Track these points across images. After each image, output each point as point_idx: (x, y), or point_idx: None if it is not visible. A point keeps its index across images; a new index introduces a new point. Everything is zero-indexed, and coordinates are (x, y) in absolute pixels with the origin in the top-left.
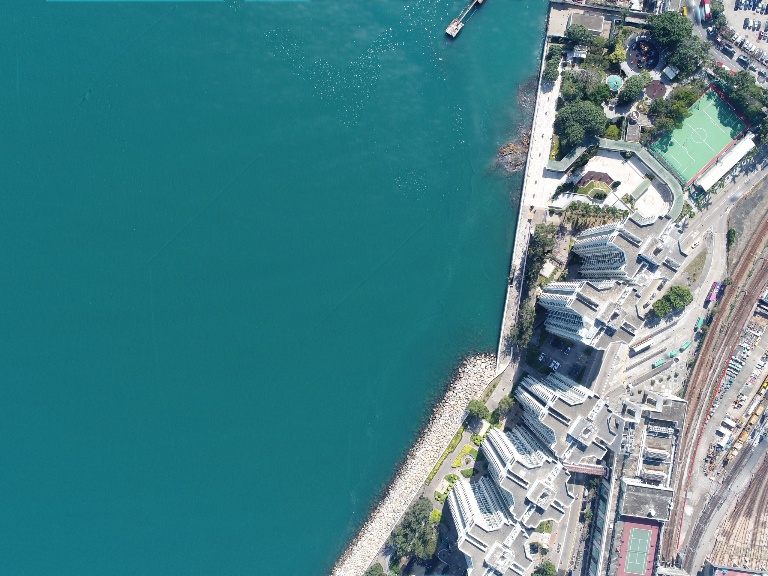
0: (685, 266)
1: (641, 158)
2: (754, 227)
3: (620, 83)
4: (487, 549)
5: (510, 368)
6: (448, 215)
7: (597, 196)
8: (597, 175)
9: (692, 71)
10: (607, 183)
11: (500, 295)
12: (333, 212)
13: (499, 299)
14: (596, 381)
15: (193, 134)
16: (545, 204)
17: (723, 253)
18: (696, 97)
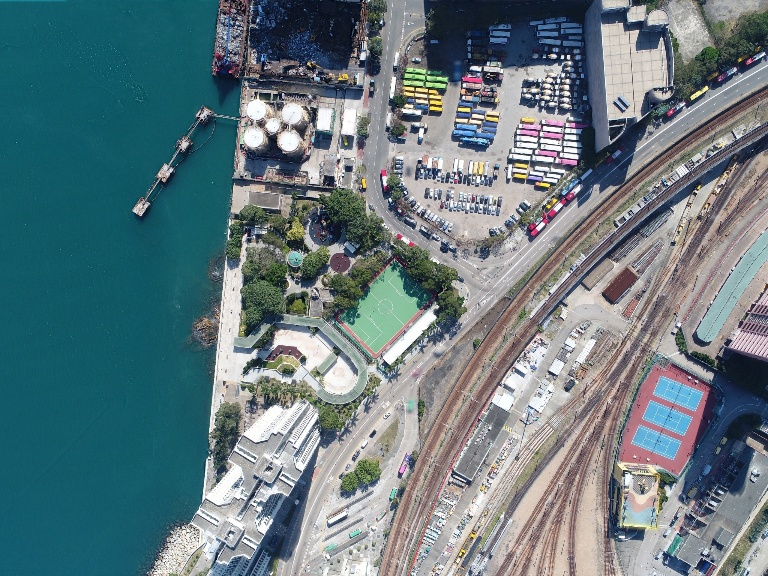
0: (378, 437)
1: (325, 333)
2: (444, 397)
3: (300, 259)
4: None
5: None
6: (124, 403)
7: (283, 372)
8: (286, 349)
9: (370, 246)
10: (296, 357)
11: (199, 468)
12: (14, 404)
13: (199, 472)
14: (296, 550)
15: None
16: (237, 378)
17: (415, 423)
18: (380, 268)
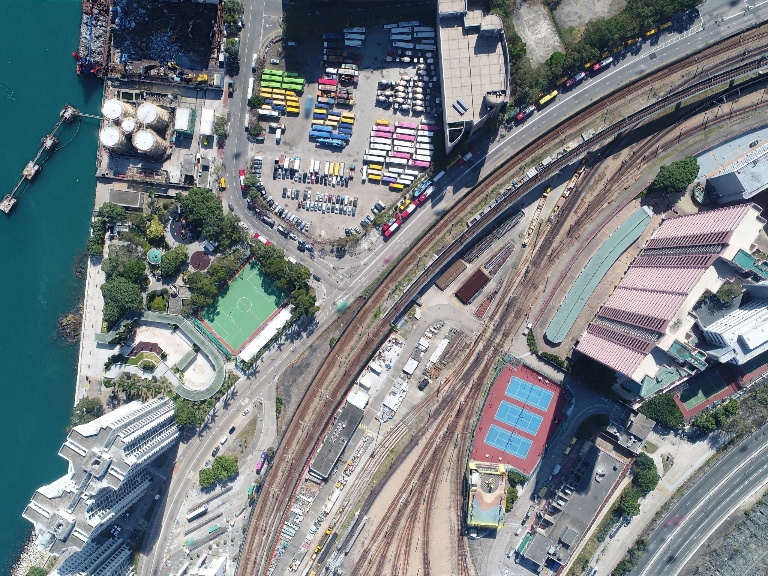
0: (237, 433)
1: (183, 330)
2: (301, 395)
3: (160, 257)
4: None
5: None
6: None
7: (143, 368)
8: (148, 345)
9: (227, 244)
10: (158, 353)
11: (62, 462)
12: None
13: (63, 466)
14: (157, 545)
15: None
16: (100, 374)
17: (273, 420)
18: (239, 267)
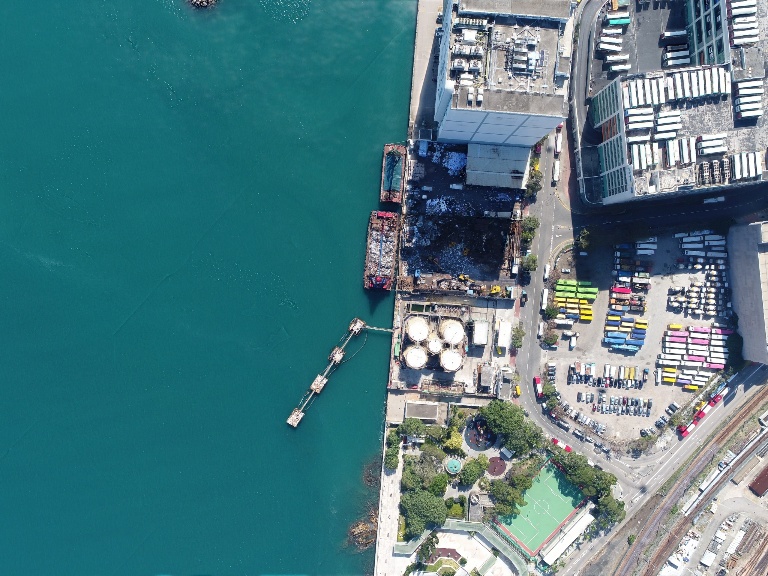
0: None
1: (485, 537)
2: None
3: (459, 467)
4: None
5: None
6: None
7: (445, 575)
8: (445, 551)
9: None
10: (455, 558)
11: None
12: None
13: None
14: None
15: (39, 567)
16: None
17: None
18: None
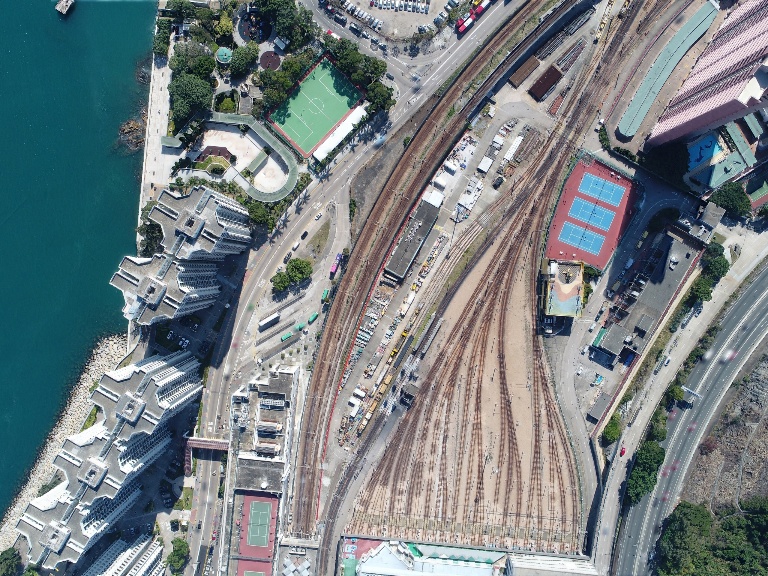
0: (309, 238)
1: (254, 131)
2: (375, 196)
3: (229, 55)
4: (44, 528)
5: (140, 347)
6: (45, 195)
7: (213, 171)
8: (216, 150)
9: (299, 41)
10: (226, 157)
11: None
12: None
13: None
14: (227, 357)
15: None
16: (166, 181)
17: (346, 224)
18: (311, 67)
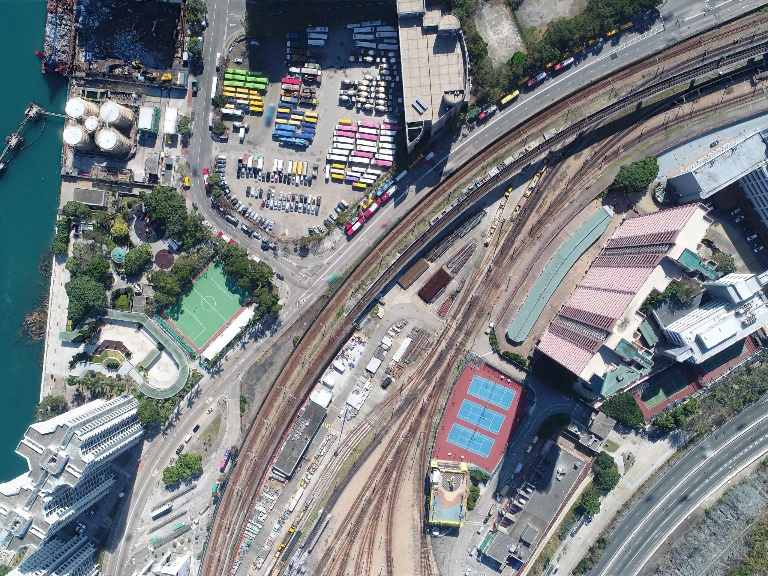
0: (201, 431)
1: None
2: (265, 393)
3: (124, 255)
4: None
5: None
6: None
7: (108, 366)
8: (112, 344)
9: (190, 243)
10: (122, 351)
11: None
12: None
13: None
14: (122, 543)
15: None
16: (65, 372)
17: (237, 418)
18: (204, 265)
